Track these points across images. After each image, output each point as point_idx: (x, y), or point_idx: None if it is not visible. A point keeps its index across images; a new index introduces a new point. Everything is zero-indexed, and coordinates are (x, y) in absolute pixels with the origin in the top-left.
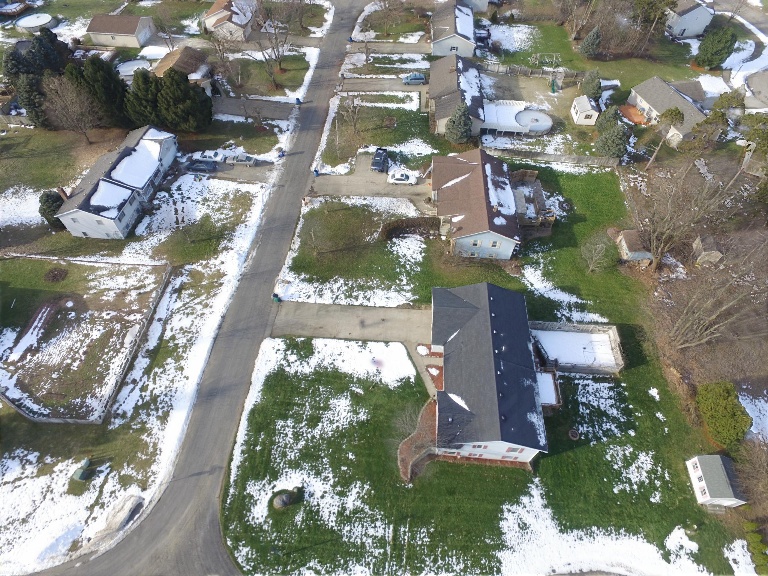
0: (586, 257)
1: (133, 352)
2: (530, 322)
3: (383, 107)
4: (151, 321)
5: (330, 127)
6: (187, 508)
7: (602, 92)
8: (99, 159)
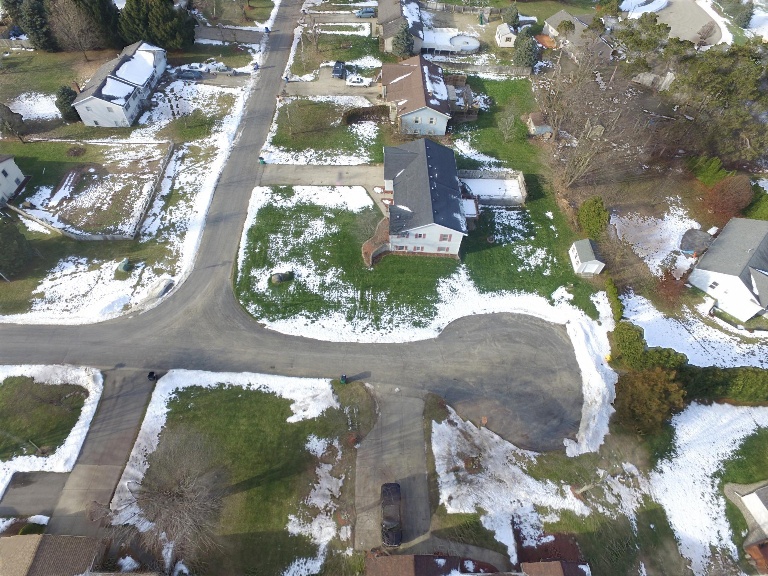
0: (502, 130)
1: (151, 197)
2: (459, 171)
3: (340, 34)
4: (162, 178)
5: (296, 49)
6: (207, 285)
7: (522, 26)
8: (102, 66)
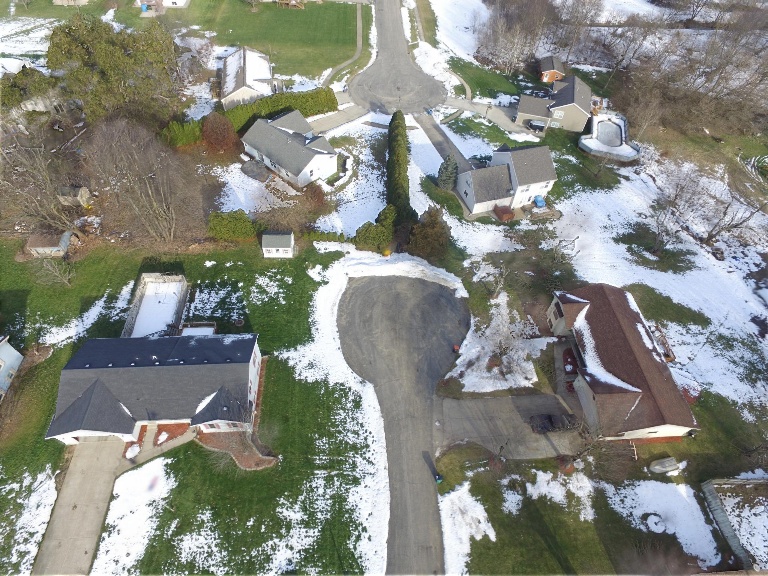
0: (52, 282)
1: None
2: None
3: None
4: None
5: None
6: None
7: None
8: None
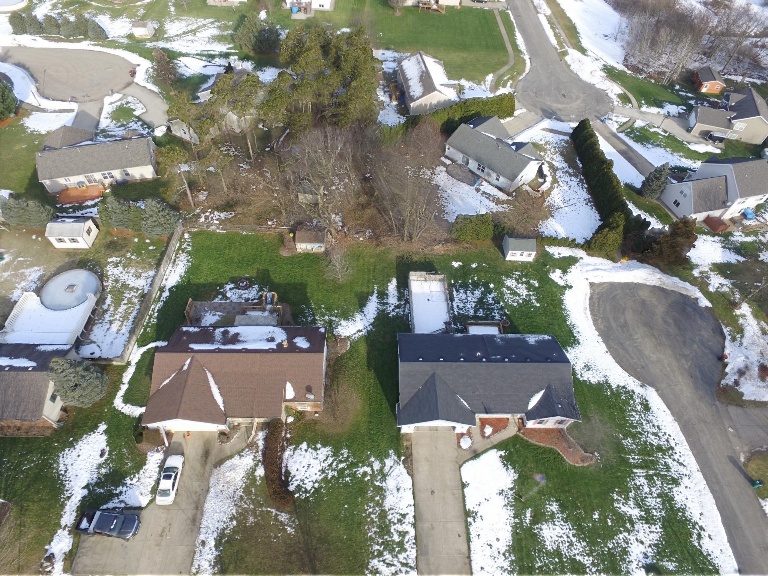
0: None
1: None
2: None
3: None
4: None
5: None
6: None
7: None
8: None
